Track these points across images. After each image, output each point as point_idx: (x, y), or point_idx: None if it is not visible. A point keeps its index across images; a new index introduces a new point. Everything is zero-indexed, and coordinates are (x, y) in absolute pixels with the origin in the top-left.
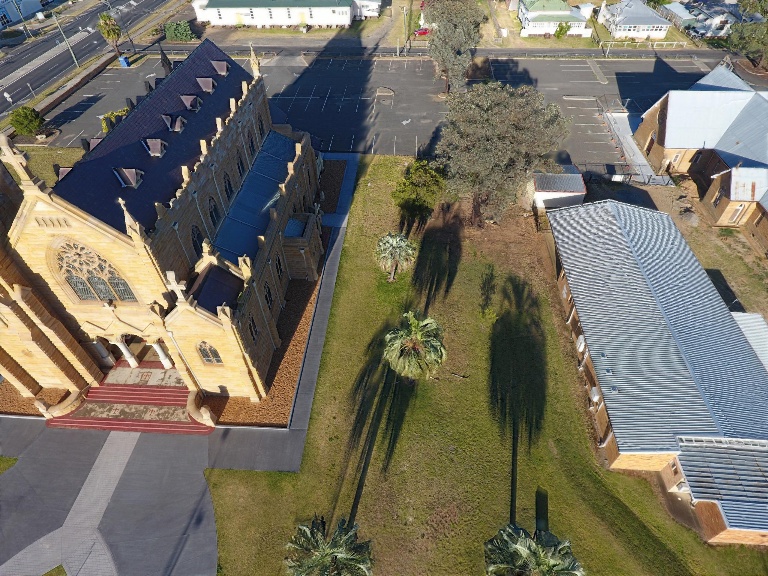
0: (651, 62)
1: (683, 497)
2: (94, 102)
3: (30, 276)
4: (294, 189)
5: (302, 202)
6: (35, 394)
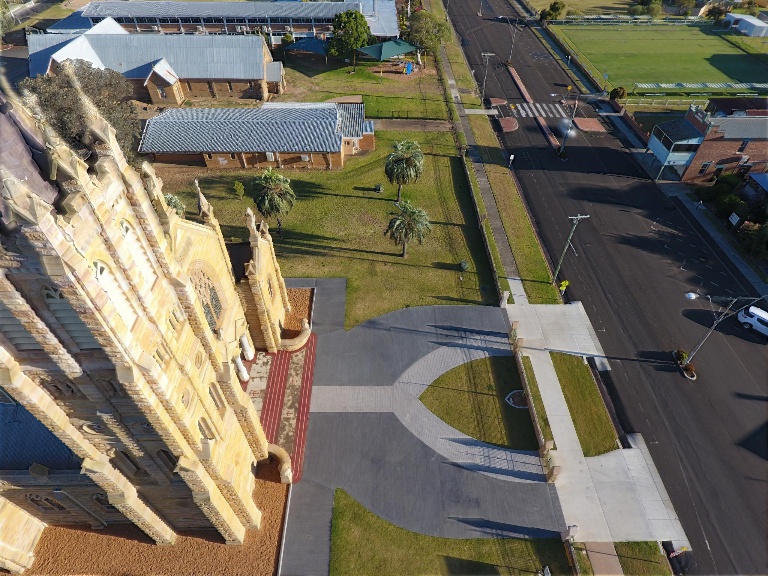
0: None
1: (356, 151)
2: None
3: None
4: None
5: None
6: None
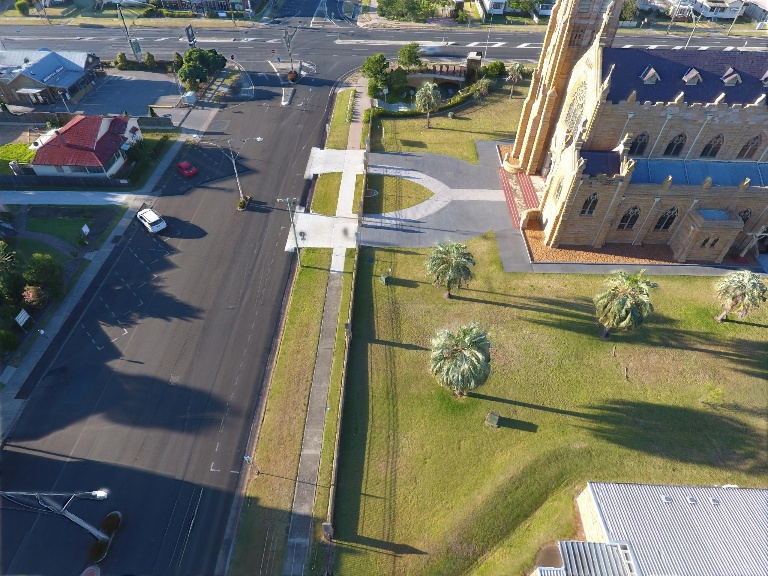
0: None
1: None
2: None
3: (565, 92)
4: (765, 202)
5: (763, 223)
6: (514, 157)
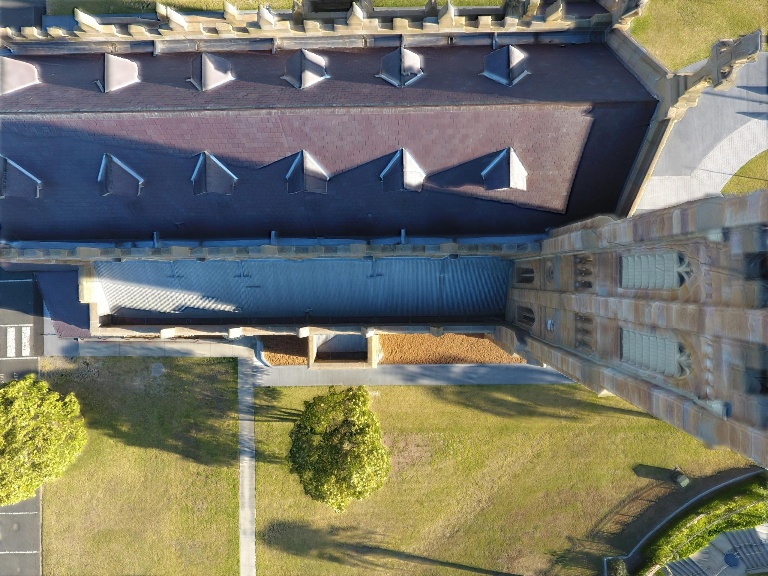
0: None
1: None
2: None
3: None
4: None
5: None
6: None
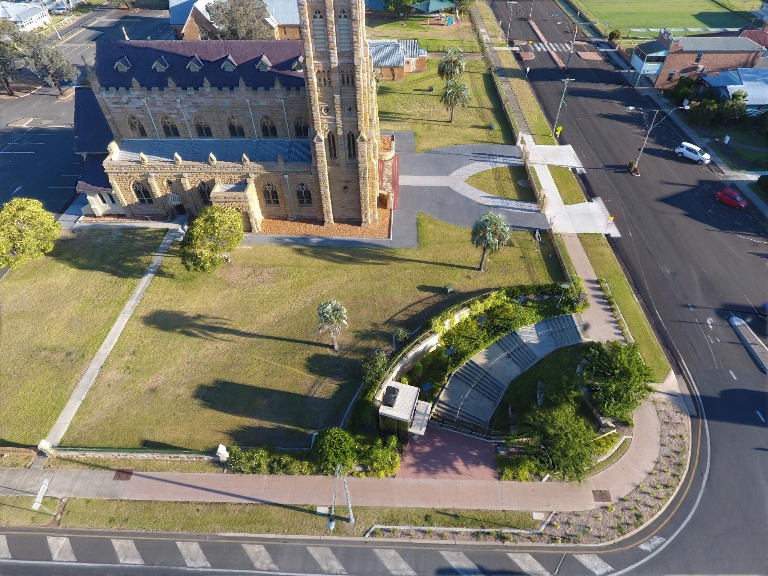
0: (87, 30)
1: (413, 70)
2: None
3: None
4: None
5: None
6: None
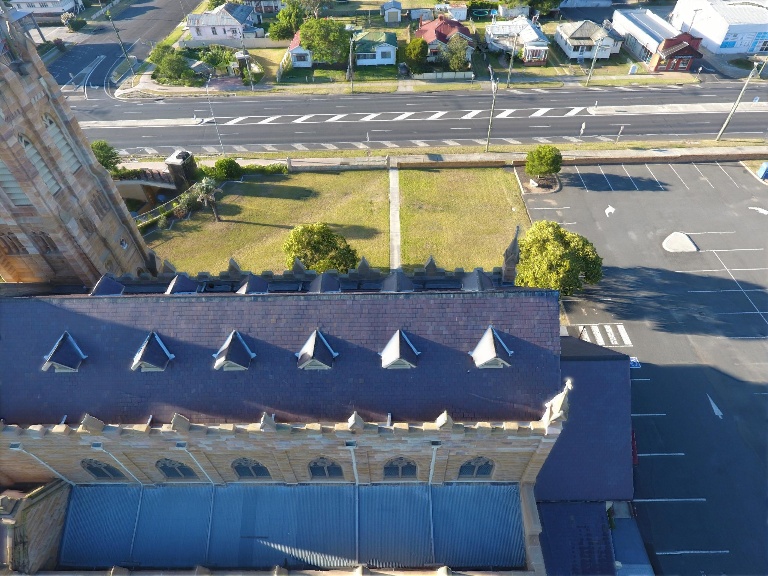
0: None
1: None
2: (641, 188)
3: None
4: None
5: None
6: None
